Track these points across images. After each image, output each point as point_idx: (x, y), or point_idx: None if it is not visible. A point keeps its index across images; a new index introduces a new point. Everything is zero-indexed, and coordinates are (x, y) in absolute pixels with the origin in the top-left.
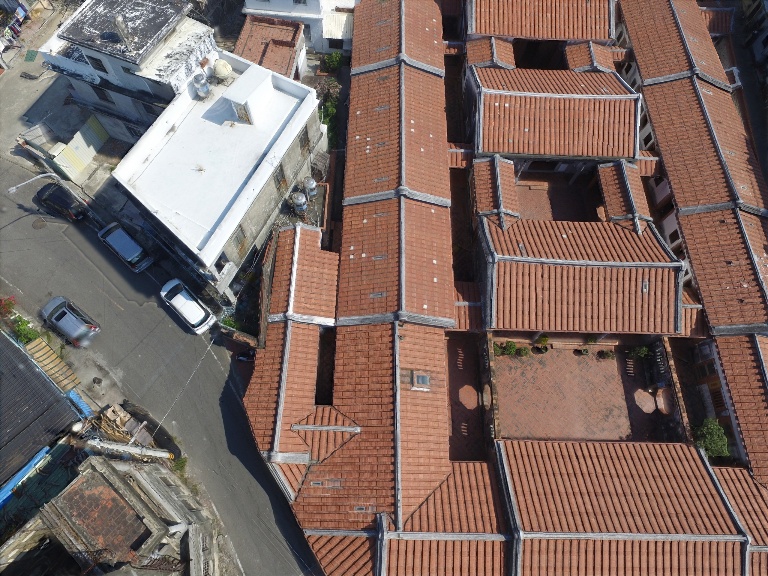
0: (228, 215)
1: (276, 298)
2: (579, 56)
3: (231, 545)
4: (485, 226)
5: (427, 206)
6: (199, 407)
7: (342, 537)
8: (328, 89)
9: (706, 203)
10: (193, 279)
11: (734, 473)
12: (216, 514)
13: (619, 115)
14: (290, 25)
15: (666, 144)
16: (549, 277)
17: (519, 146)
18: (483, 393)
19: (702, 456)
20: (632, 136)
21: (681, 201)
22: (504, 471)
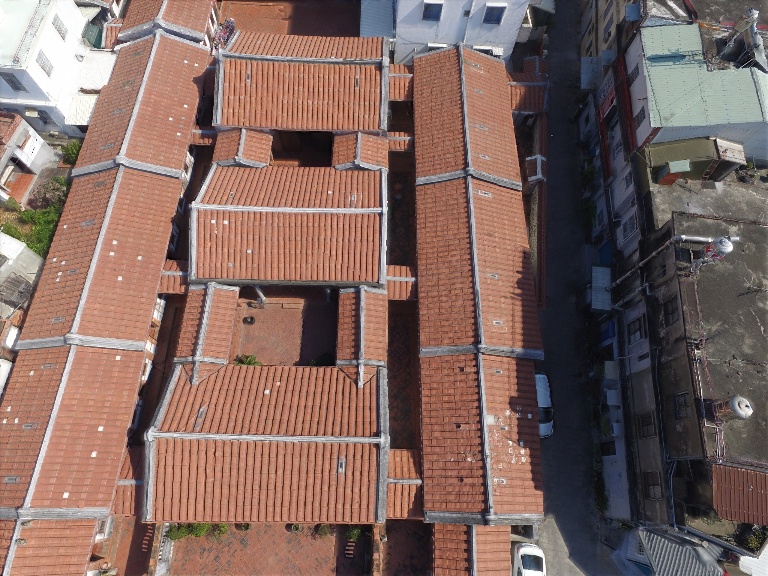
0: None
1: None
2: (345, 149)
3: None
4: (172, 379)
5: (111, 352)
6: None
7: None
8: (45, 193)
9: (449, 344)
10: None
11: None
12: None
13: (361, 232)
14: (8, 116)
15: (424, 262)
16: (223, 455)
17: (241, 270)
18: None
19: None
20: (377, 257)
21: (425, 339)
22: None
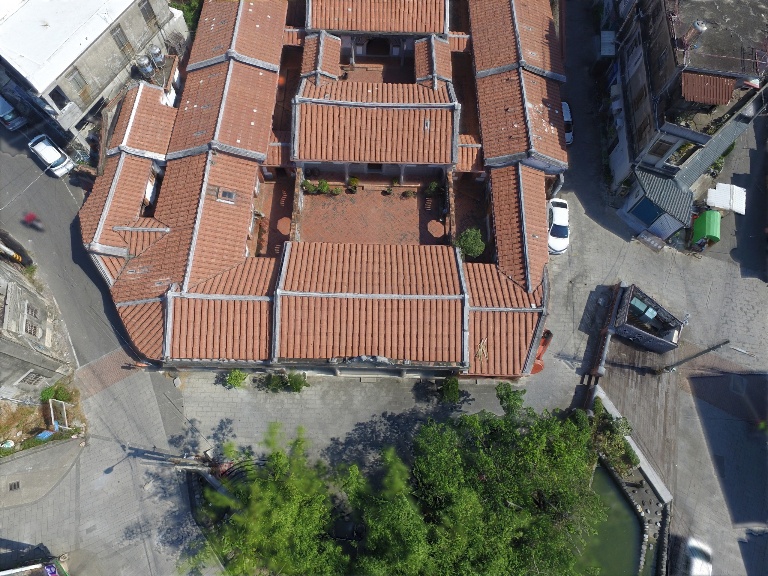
0: (57, 51)
1: (116, 137)
2: None
3: (65, 327)
4: (302, 83)
5: (256, 69)
6: (52, 230)
7: (143, 305)
8: None
9: (498, 66)
10: (60, 136)
11: (484, 266)
12: (56, 305)
13: None
14: None
15: (476, 24)
16: (345, 117)
17: (343, 23)
18: (297, 222)
19: (456, 252)
20: (442, 14)
21: (479, 66)
22: (283, 258)
